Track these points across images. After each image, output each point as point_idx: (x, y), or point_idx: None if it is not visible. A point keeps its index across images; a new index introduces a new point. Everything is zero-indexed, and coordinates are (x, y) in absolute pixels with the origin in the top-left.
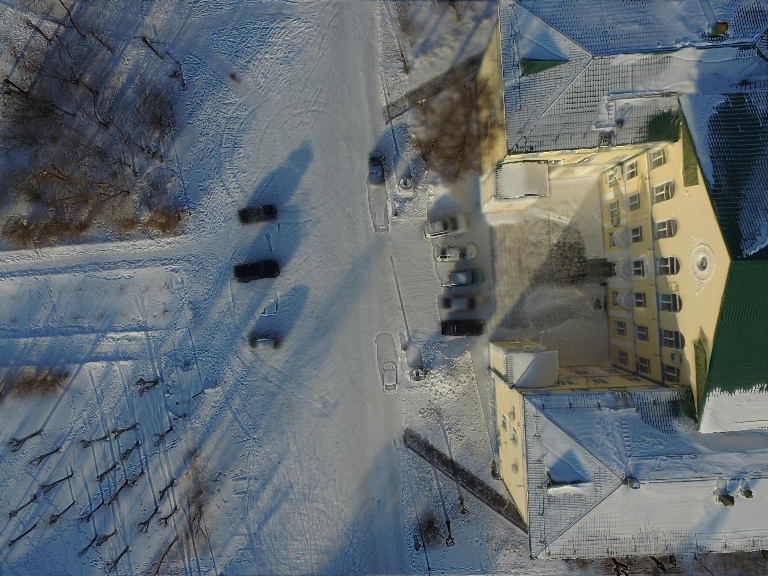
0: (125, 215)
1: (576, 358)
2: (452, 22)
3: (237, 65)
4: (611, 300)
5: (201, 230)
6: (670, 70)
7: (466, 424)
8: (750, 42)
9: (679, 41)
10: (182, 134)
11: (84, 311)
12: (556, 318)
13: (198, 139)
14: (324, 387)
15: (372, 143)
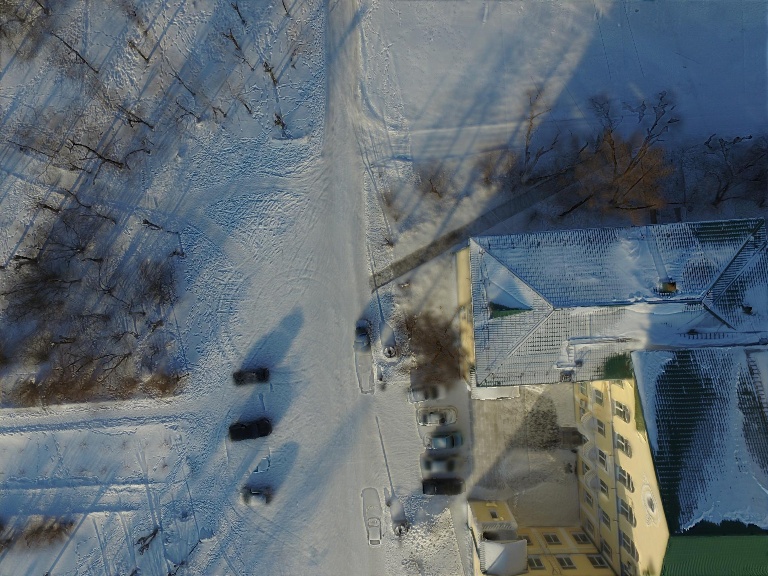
0: (127, 375)
1: (548, 519)
2: (434, 198)
3: (233, 235)
4: (581, 468)
5: (198, 389)
6: (625, 320)
7: (446, 575)
8: (697, 298)
9: (633, 295)
10: (181, 300)
11: (89, 464)
12: (530, 481)
13: (196, 304)
14: (313, 537)
15: (359, 310)
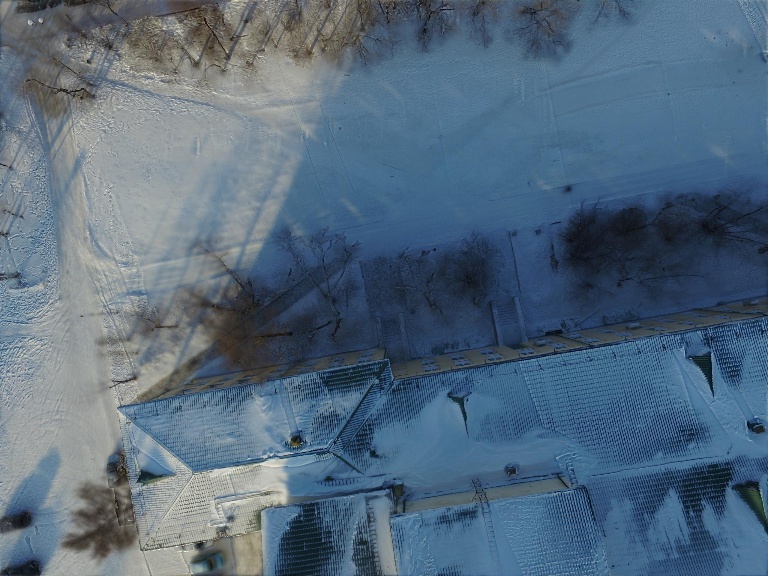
0: None
1: None
2: (171, 328)
3: None
4: None
5: None
6: (263, 475)
7: None
8: (324, 448)
9: (265, 452)
10: None
11: None
12: None
13: None
14: None
15: (113, 444)
